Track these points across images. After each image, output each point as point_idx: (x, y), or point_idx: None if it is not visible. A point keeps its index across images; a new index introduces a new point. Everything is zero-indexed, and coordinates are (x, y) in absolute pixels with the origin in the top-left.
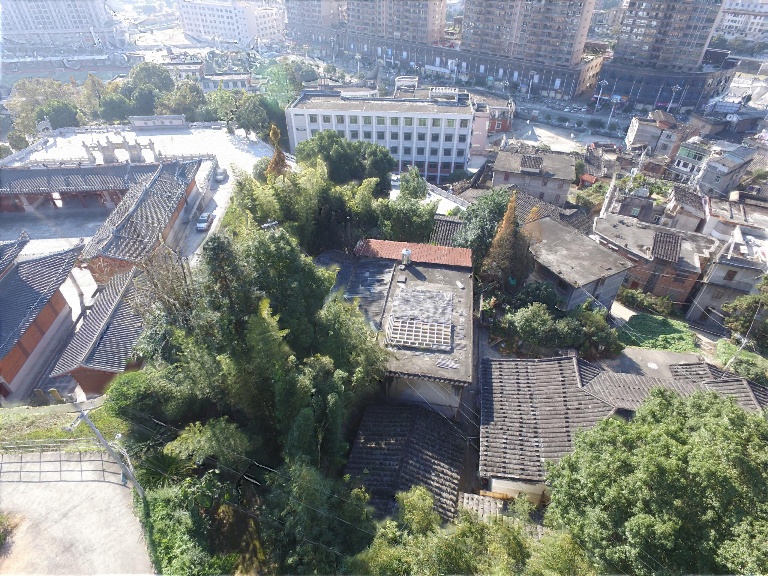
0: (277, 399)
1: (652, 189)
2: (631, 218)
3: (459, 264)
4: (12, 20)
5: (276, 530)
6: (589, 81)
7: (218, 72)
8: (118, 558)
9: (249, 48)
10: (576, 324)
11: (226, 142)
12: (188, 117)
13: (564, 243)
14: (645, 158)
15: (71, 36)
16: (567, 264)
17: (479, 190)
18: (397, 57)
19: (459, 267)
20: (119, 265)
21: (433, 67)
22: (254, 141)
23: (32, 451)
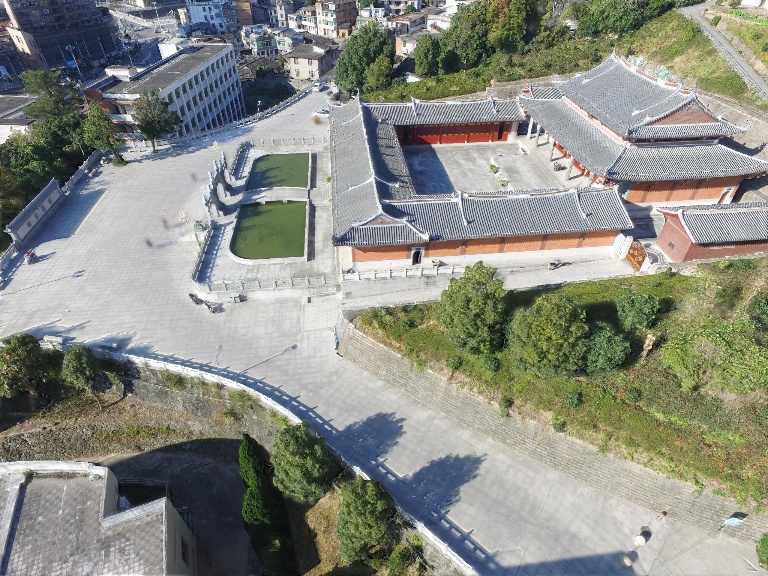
0: None
1: None
2: (402, 35)
3: None
4: None
5: None
6: None
7: None
8: None
9: None
10: None
11: (165, 160)
12: (23, 196)
13: None
14: None
15: None
16: None
17: (325, 76)
18: None
19: None
20: None
21: None
22: None
23: None
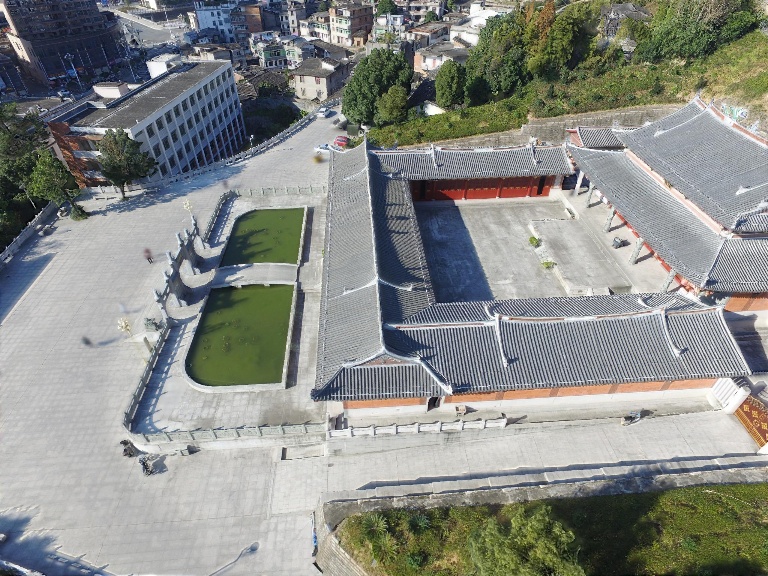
0: None
1: None
2: (421, 49)
3: None
4: None
5: None
6: None
7: None
8: None
9: None
10: None
11: (133, 212)
12: None
13: None
14: None
15: None
16: None
17: (333, 96)
18: None
19: None
20: None
21: None
22: None
23: None
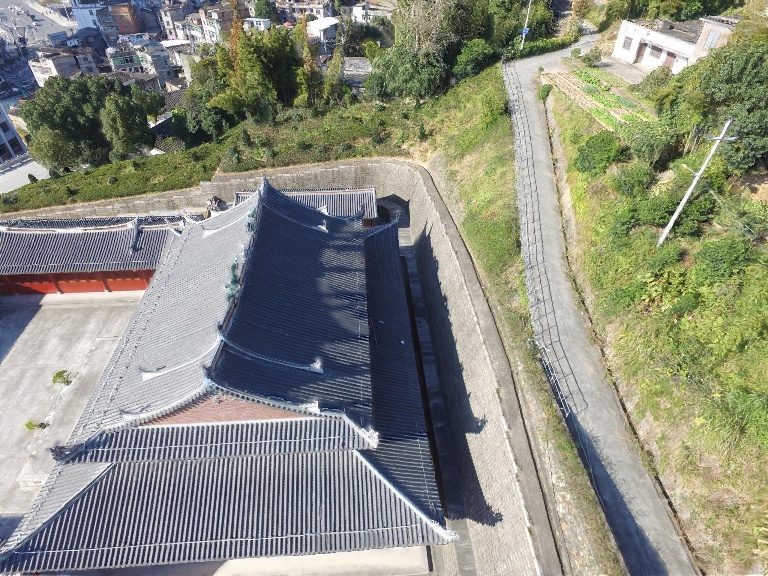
0: None
1: None
2: None
3: None
4: None
5: None
6: None
7: None
8: None
9: None
10: None
11: None
12: None
13: None
14: None
15: None
16: None
17: None
18: None
19: None
20: None
21: None
22: None
23: None
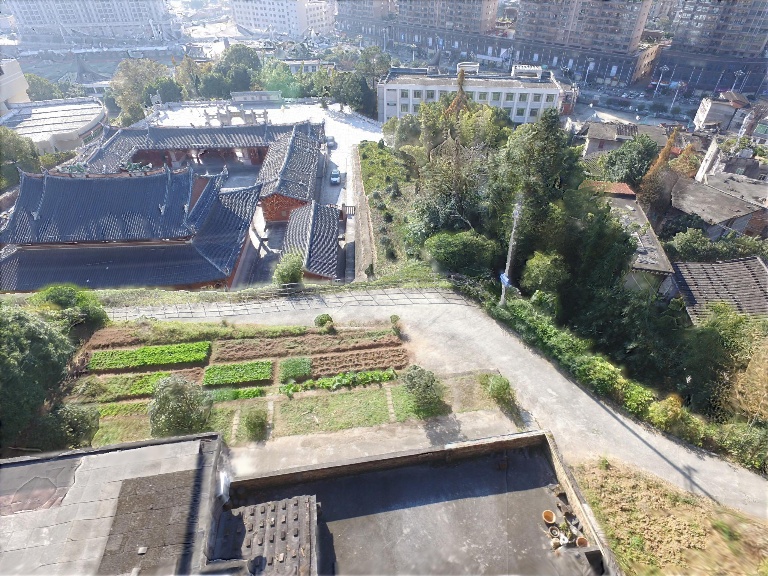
0: (591, 240)
1: (757, 150)
2: (740, 175)
3: (623, 192)
4: (77, 13)
5: (592, 340)
6: (644, 69)
7: (289, 58)
8: (495, 343)
9: (302, 39)
10: (733, 245)
11: (323, 115)
12: (281, 94)
13: (688, 191)
14: (748, 122)
15: (131, 29)
16: (697, 207)
17: None
18: (448, 47)
19: (623, 195)
20: (288, 204)
21: (485, 56)
22: (349, 114)
23: (373, 289)
